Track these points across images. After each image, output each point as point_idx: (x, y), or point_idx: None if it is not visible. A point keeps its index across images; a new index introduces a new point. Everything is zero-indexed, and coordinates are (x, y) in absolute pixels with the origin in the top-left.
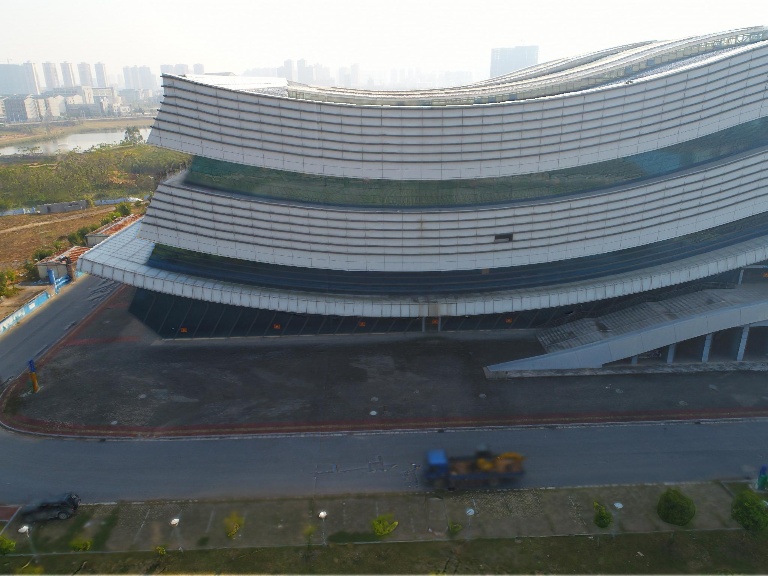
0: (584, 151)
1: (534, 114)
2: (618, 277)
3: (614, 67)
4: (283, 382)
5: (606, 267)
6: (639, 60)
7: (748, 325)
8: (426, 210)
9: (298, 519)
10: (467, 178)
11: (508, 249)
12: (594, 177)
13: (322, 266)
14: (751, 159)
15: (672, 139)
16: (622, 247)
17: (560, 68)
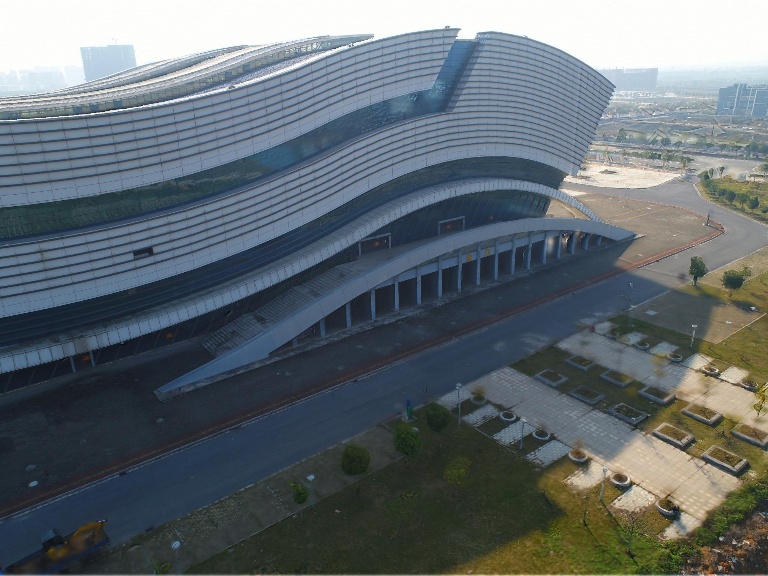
0: (205, 156)
1: (145, 122)
2: (264, 270)
3: (214, 72)
4: None
5: (251, 263)
6: (236, 65)
7: (373, 288)
8: (44, 238)
9: None
10: (86, 196)
11: (151, 263)
12: (220, 180)
13: None
14: (345, 150)
15: (281, 138)
16: (261, 242)
17: (161, 72)
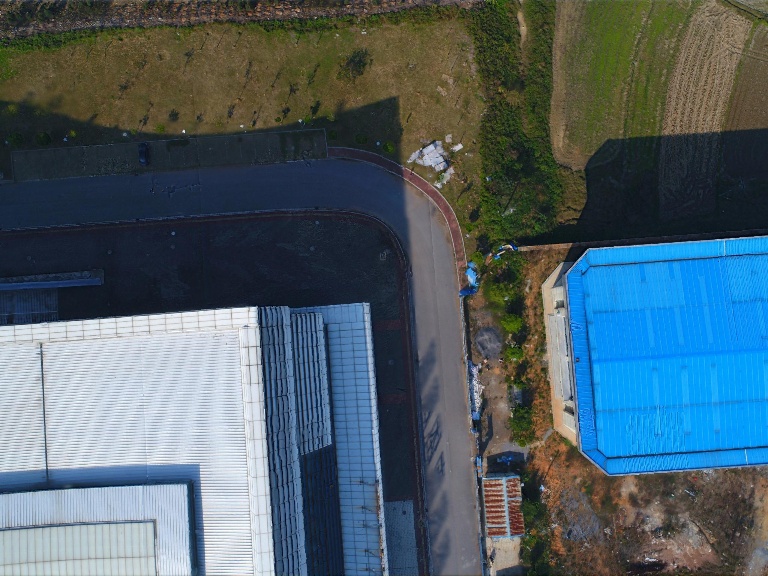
0: None
1: None
2: None
3: None
4: (230, 265)
5: None
6: None
7: None
8: None
9: (203, 153)
10: None
11: None
12: None
13: None
14: None
15: None
16: None
17: None
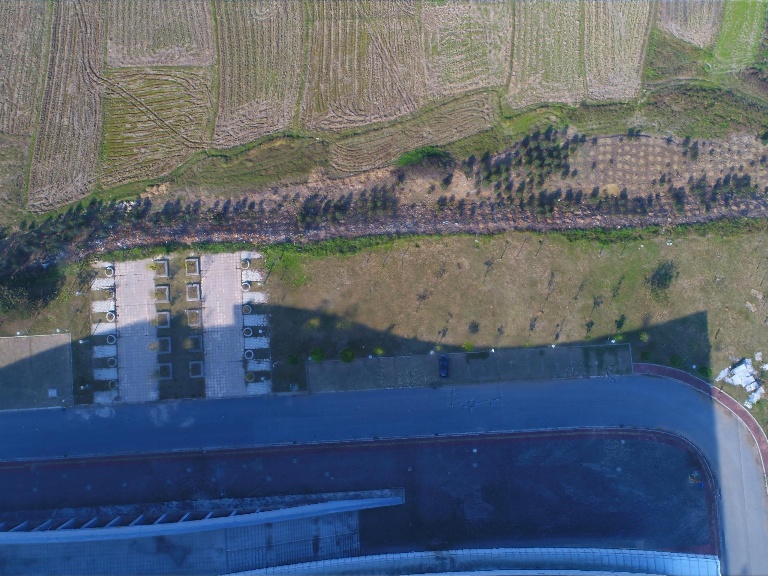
0: None
1: None
2: None
3: None
4: (534, 485)
5: None
6: None
7: None
8: None
9: (504, 367)
10: None
11: None
12: None
13: (529, 571)
14: None
15: None
16: None
17: None
